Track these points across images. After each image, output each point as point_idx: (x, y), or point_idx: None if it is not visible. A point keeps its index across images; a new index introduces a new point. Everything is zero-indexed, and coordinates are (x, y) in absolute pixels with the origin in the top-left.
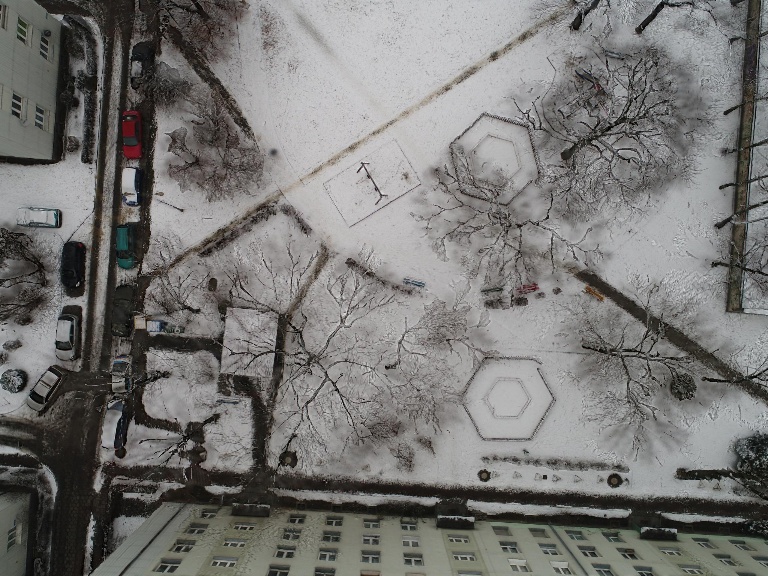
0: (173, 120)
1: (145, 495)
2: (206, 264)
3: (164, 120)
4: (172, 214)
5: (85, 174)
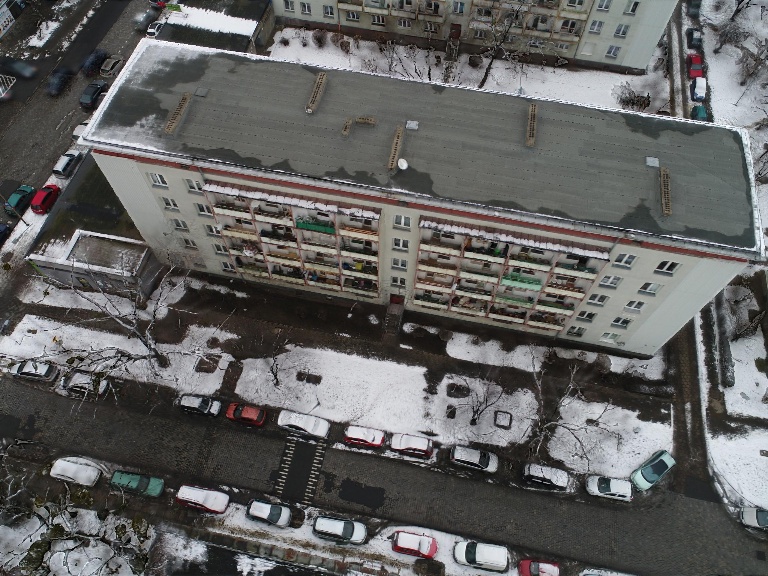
0: (720, 63)
1: (741, 271)
2: (759, 135)
3: (713, 62)
4: (729, 106)
5: (662, 82)
